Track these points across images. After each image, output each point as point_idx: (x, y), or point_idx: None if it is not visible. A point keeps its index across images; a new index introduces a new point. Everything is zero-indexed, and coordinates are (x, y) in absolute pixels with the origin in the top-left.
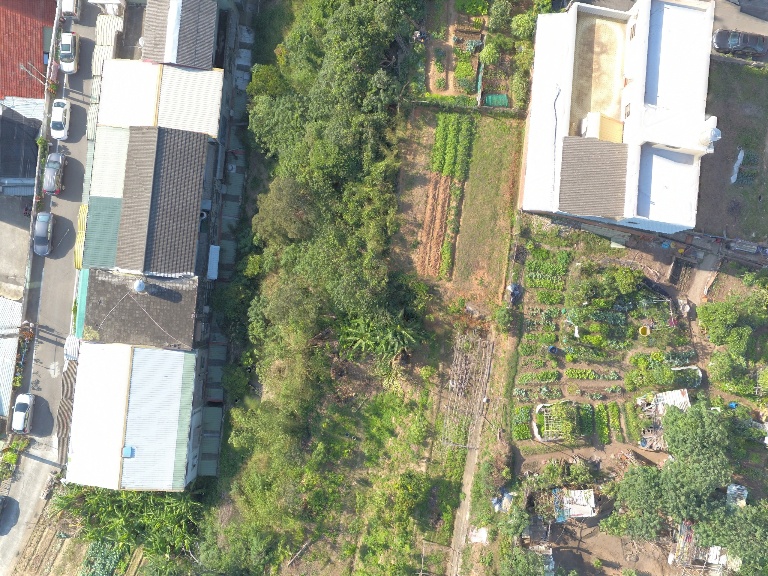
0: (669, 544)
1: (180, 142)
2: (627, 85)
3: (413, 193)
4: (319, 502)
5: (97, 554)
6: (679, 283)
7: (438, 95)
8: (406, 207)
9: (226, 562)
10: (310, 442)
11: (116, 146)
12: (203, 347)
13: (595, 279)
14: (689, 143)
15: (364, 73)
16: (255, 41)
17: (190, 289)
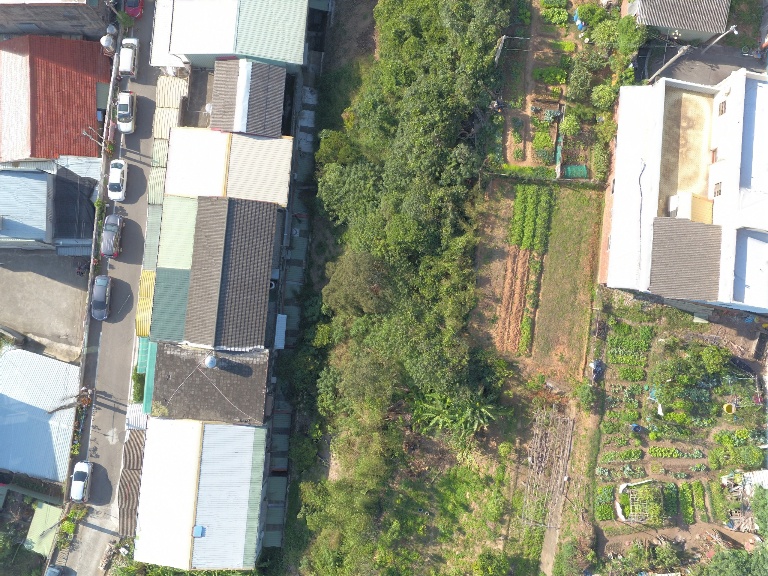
0: None
1: (250, 213)
2: (716, 162)
3: (491, 267)
4: None
5: None
6: (763, 358)
7: (516, 167)
8: (484, 281)
9: None
10: (382, 517)
11: (184, 216)
12: (270, 418)
13: None
14: None
15: (444, 147)
16: (319, 102)
17: (261, 363)
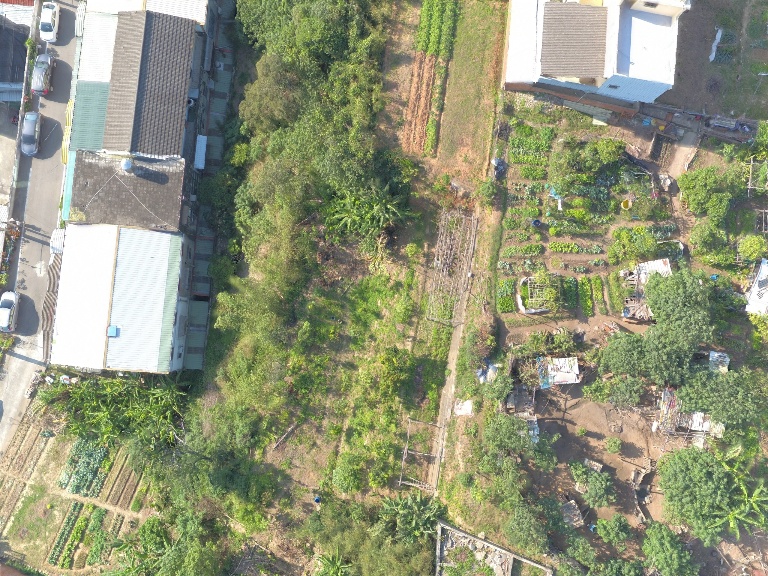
0: (653, 414)
1: (168, 26)
2: None
3: (398, 72)
4: (305, 385)
5: (81, 452)
6: (660, 159)
7: None
8: (391, 86)
9: (211, 447)
10: (296, 326)
11: (104, 31)
12: (190, 236)
13: (577, 152)
14: None
15: None
16: None
17: (177, 171)
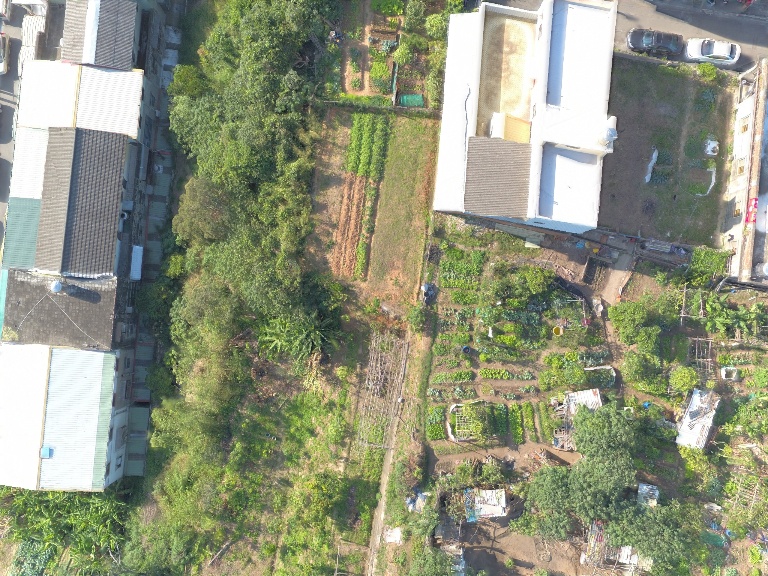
0: (582, 544)
1: (98, 143)
2: (535, 85)
3: (328, 193)
4: (239, 502)
5: (26, 554)
6: (594, 283)
7: (353, 95)
8: (321, 207)
9: (148, 562)
10: (231, 442)
11: (35, 147)
12: (127, 347)
13: (508, 279)
14: (588, 143)
15: (276, 73)
16: (182, 41)
17: (109, 290)
